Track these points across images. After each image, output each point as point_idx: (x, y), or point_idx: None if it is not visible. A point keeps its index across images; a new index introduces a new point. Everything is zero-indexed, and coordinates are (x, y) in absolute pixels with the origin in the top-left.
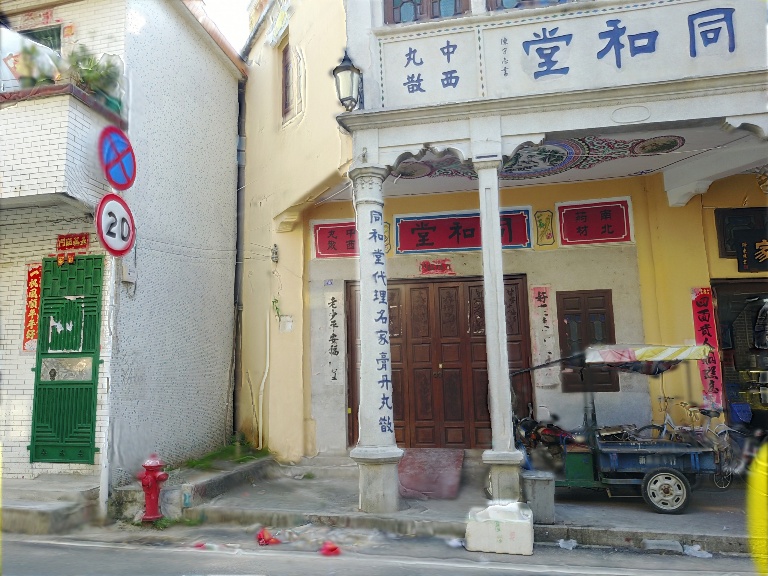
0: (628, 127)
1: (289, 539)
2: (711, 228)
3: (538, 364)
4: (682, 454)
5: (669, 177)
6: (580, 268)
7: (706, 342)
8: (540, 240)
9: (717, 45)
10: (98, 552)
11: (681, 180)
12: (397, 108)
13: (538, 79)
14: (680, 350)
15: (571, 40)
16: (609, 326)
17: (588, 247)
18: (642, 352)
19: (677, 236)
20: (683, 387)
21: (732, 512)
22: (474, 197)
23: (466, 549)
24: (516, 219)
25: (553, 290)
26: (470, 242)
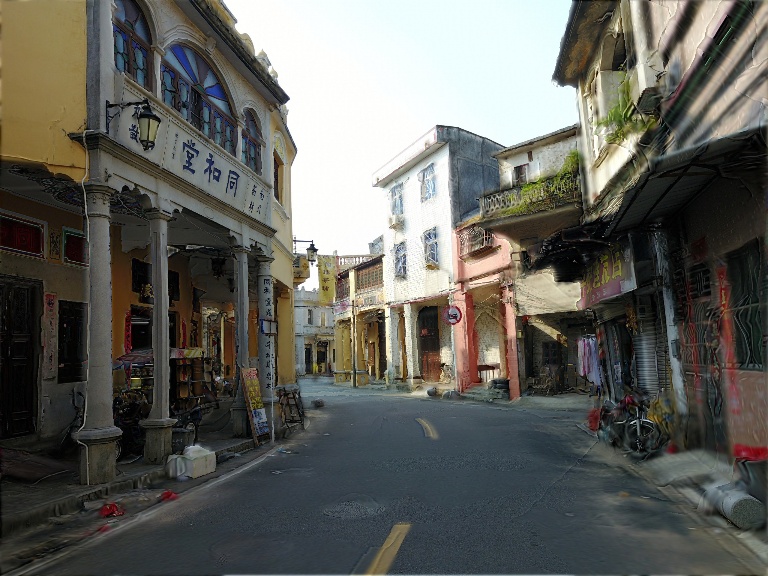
0: (206, 219)
1: (119, 508)
2: (130, 270)
3: (45, 360)
4: (192, 412)
5: (126, 231)
6: (74, 283)
7: (128, 346)
8: (52, 254)
9: (232, 191)
10: (68, 561)
11: (135, 237)
12: (123, 145)
13: (184, 170)
14: (195, 352)
15: (198, 155)
16: (85, 331)
17: (79, 268)
18: (186, 352)
19: (122, 272)
20: (120, 376)
21: (203, 440)
22: (12, 199)
23: (193, 478)
24: (35, 230)
25: (57, 298)
26: (1, 241)
